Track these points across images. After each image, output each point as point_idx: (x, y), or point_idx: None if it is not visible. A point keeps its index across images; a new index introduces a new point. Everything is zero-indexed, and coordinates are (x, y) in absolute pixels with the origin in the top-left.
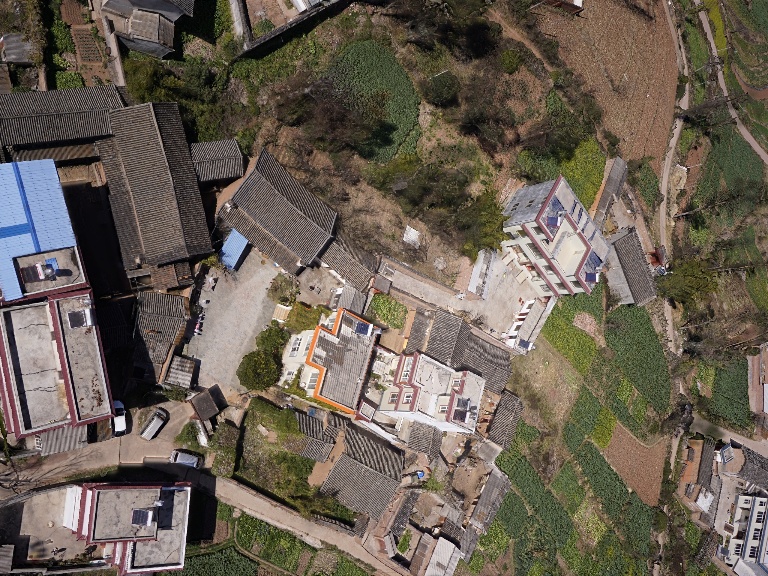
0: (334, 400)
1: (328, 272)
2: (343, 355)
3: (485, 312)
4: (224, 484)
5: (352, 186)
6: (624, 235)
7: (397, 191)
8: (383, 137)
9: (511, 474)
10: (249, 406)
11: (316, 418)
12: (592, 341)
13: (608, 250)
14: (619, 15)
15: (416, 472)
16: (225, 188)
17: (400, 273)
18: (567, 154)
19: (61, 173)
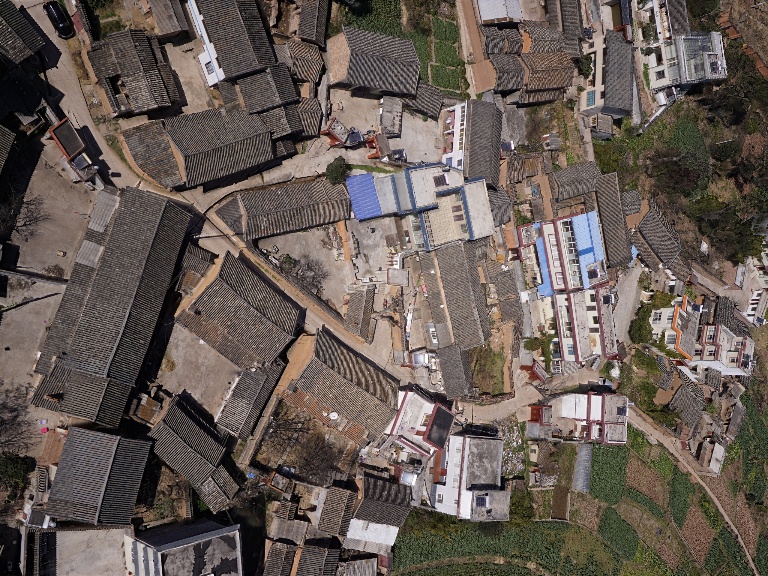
0: (685, 351)
1: (663, 271)
2: (688, 324)
3: (735, 298)
4: None
5: (676, 215)
6: None
7: (702, 219)
8: (694, 183)
9: None
10: (636, 353)
11: None
12: None
13: None
14: None
15: None
16: None
17: (696, 271)
18: None
19: (561, 212)
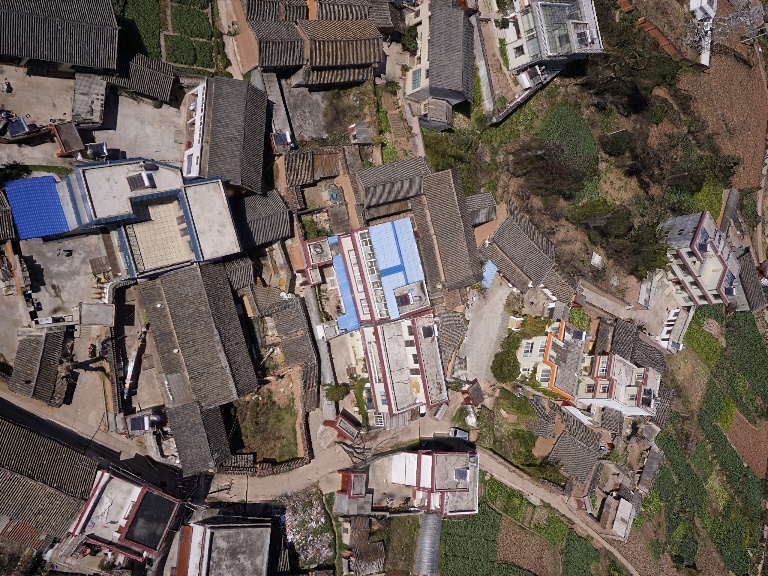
0: (562, 390)
1: (541, 290)
2: (566, 355)
3: (644, 319)
4: (480, 454)
5: (556, 222)
6: (741, 254)
7: None
8: None
9: (663, 450)
10: (500, 395)
11: (540, 404)
12: (717, 342)
13: (739, 268)
14: (730, 68)
15: (600, 447)
16: (477, 228)
17: (587, 290)
18: (697, 188)
19: None
